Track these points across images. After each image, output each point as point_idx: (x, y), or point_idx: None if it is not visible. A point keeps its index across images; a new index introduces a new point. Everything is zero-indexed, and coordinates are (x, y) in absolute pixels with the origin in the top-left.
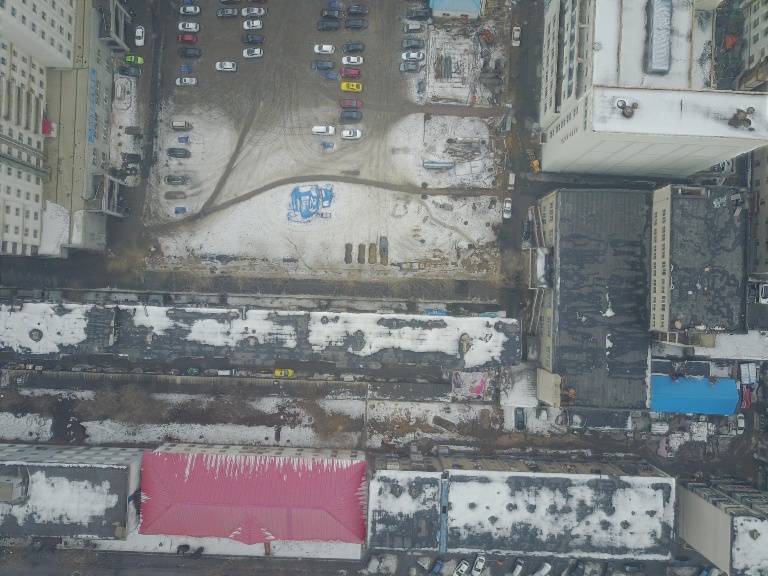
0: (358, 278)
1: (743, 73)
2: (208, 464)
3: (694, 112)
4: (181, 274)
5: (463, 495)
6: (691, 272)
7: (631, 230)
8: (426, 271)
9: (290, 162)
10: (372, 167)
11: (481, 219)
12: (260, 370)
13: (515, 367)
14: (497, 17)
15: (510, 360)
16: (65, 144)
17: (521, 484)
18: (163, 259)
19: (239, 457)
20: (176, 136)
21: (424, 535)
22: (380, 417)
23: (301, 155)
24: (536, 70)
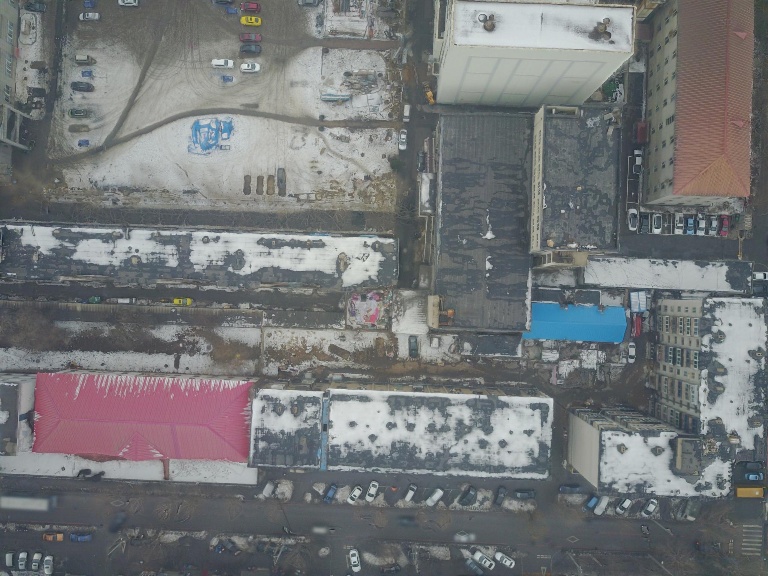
0: (256, 209)
1: (635, 3)
2: (99, 384)
3: (554, 25)
4: (84, 205)
5: (344, 414)
6: (564, 191)
7: (512, 154)
8: (323, 202)
9: (191, 95)
10: (271, 100)
11: (377, 151)
12: (160, 299)
13: (407, 295)
14: None
15: (387, 279)
16: None
17: (401, 403)
18: (67, 190)
19: (129, 377)
20: (80, 70)
21: (306, 453)
22: (277, 345)
23: (201, 88)
24: (433, 3)
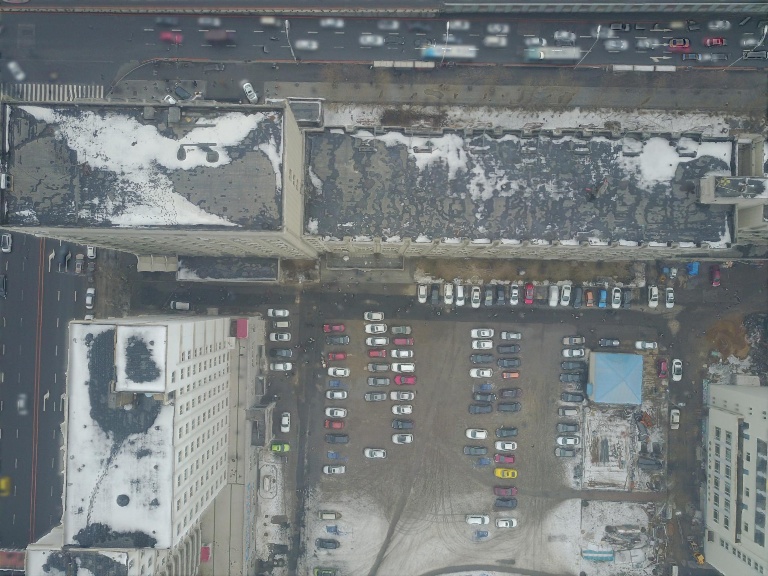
0: None
1: None
2: None
3: None
4: None
5: None
6: None
7: None
8: None
9: (443, 551)
10: (528, 556)
11: None
12: None
13: None
14: (654, 397)
15: None
16: (220, 563)
17: None
18: None
19: None
20: (324, 525)
21: None
22: None
23: (454, 544)
24: (695, 453)
